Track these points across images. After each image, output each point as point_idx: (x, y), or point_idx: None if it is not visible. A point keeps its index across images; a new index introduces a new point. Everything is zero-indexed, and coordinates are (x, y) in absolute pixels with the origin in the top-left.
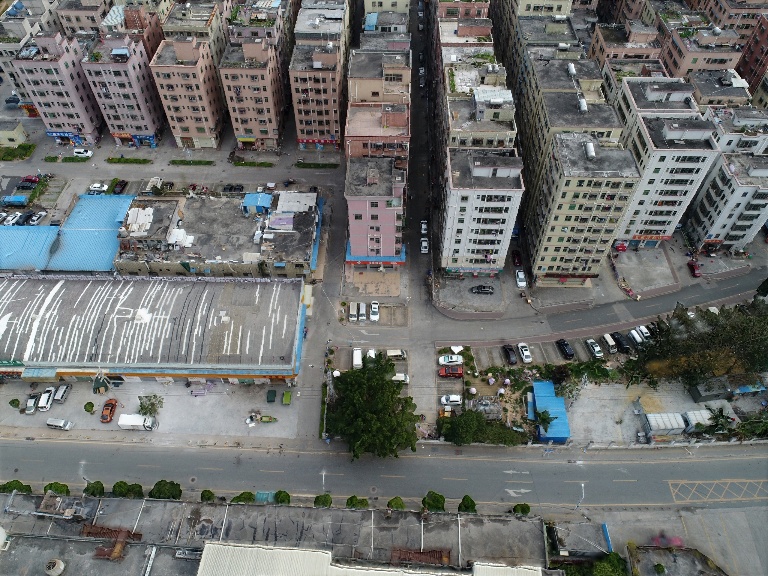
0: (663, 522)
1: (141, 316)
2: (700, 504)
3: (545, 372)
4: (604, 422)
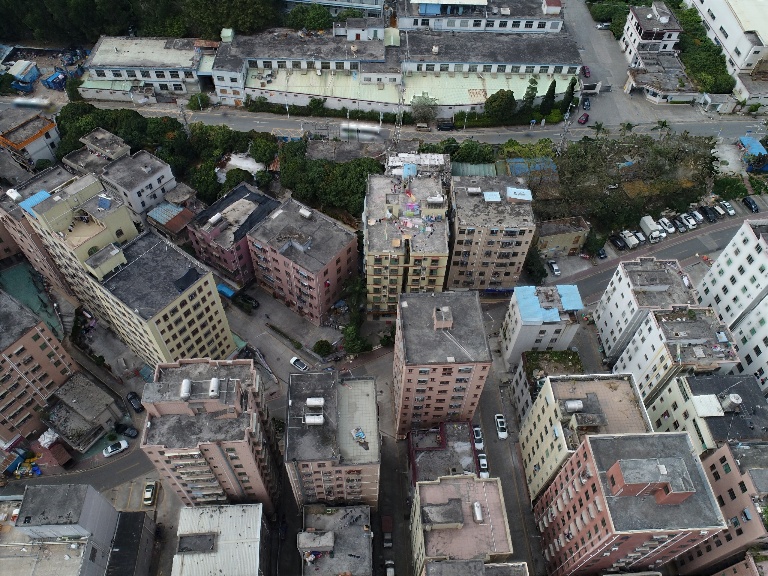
0: (669, 118)
1: None
2: (649, 125)
3: (761, 186)
4: None
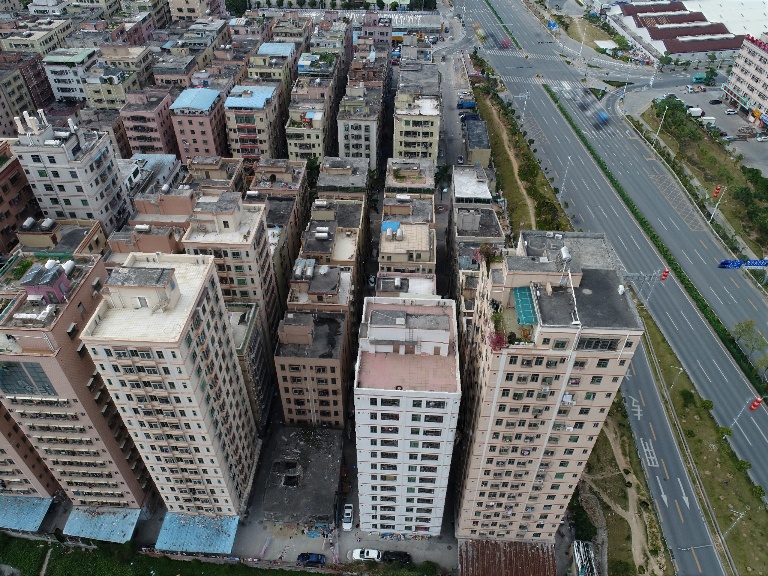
0: None
1: (314, 14)
2: None
3: None
4: None
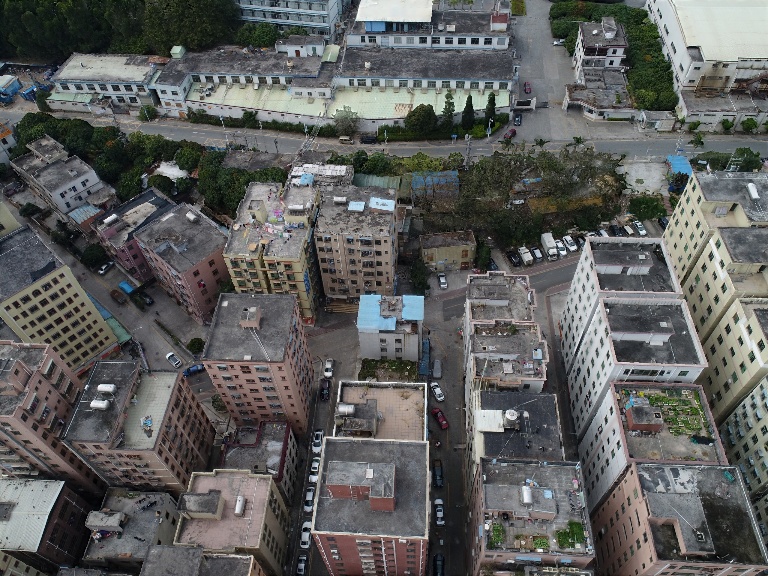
0: (602, 135)
1: None
2: None
3: None
4: (637, 174)
